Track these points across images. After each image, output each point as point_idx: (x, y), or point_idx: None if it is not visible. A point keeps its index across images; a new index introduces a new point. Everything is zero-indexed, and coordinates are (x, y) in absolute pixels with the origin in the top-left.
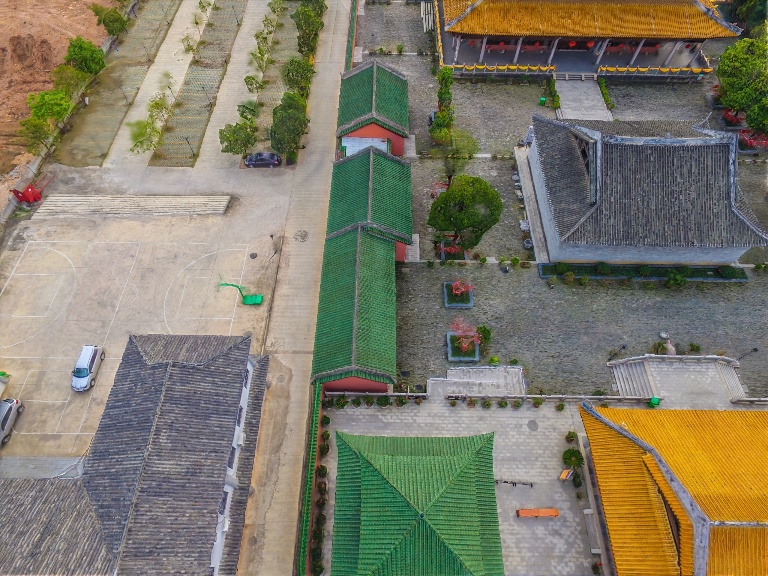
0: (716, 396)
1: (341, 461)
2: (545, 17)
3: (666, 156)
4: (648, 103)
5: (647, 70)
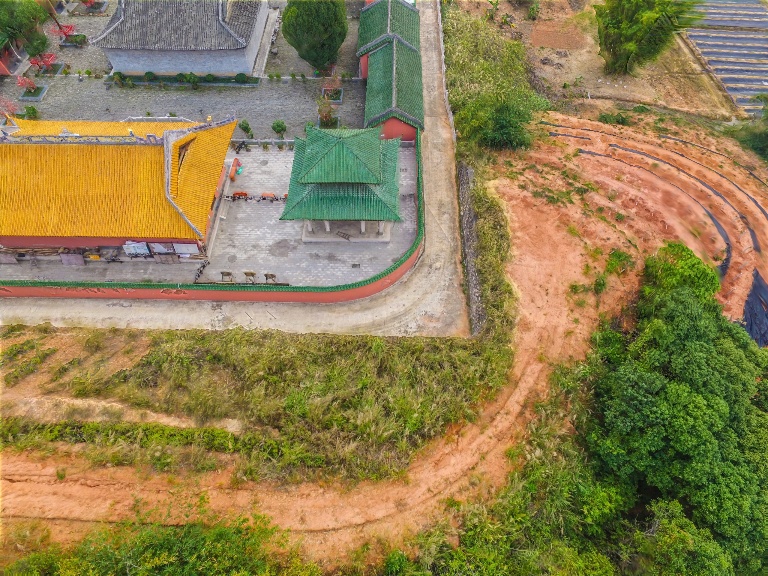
0: None
1: None
2: None
3: None
4: None
5: None
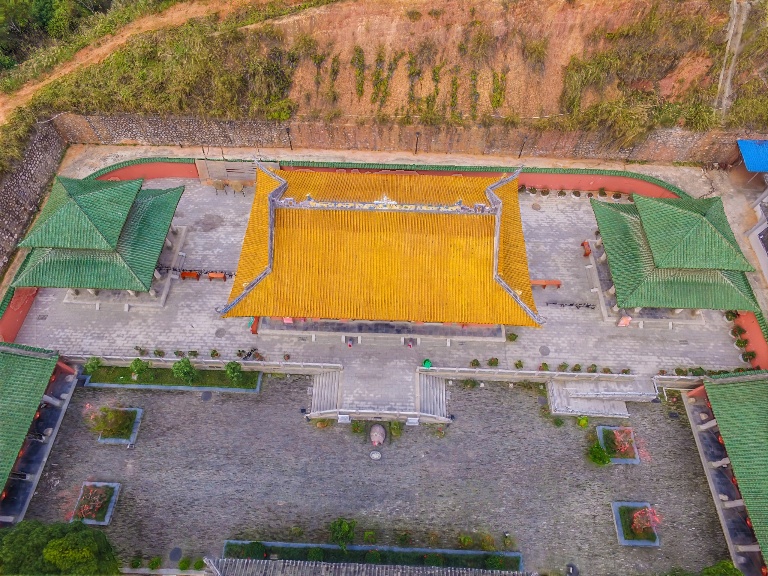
0: (356, 374)
1: (746, 290)
2: None
3: None
4: None
5: None
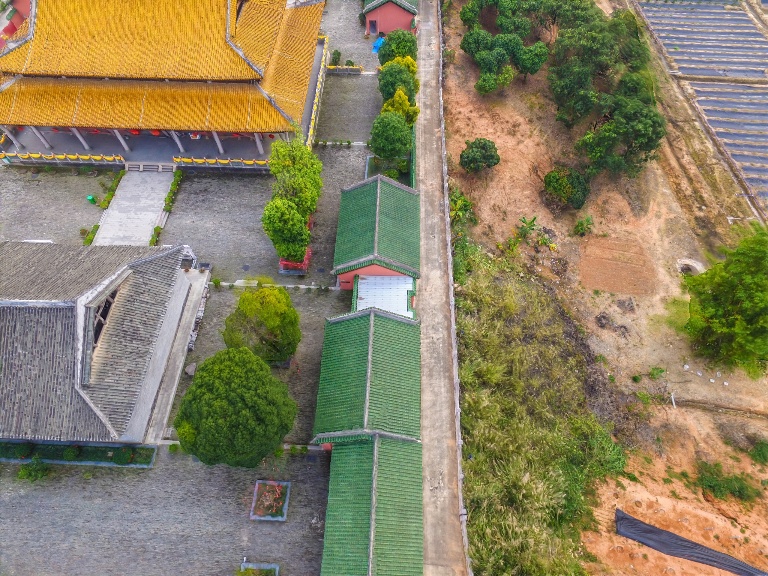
0: None
1: None
2: (83, 104)
3: (7, 320)
4: (222, 202)
5: (229, 162)
